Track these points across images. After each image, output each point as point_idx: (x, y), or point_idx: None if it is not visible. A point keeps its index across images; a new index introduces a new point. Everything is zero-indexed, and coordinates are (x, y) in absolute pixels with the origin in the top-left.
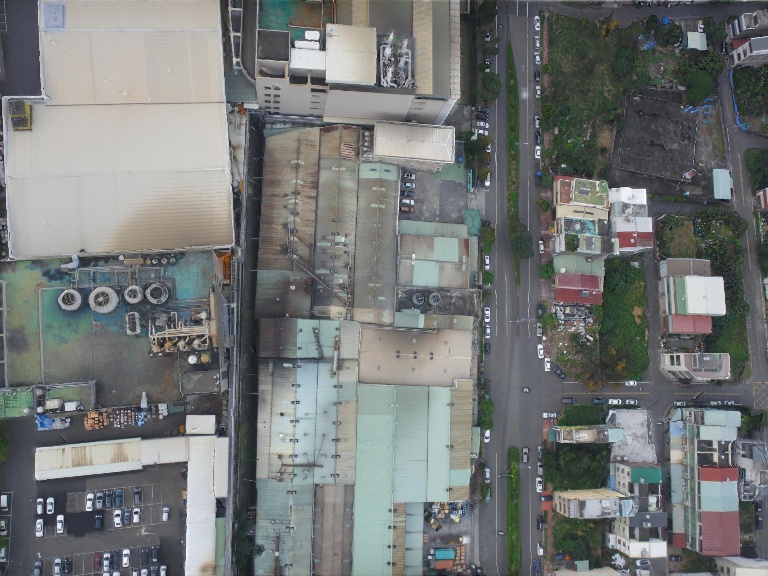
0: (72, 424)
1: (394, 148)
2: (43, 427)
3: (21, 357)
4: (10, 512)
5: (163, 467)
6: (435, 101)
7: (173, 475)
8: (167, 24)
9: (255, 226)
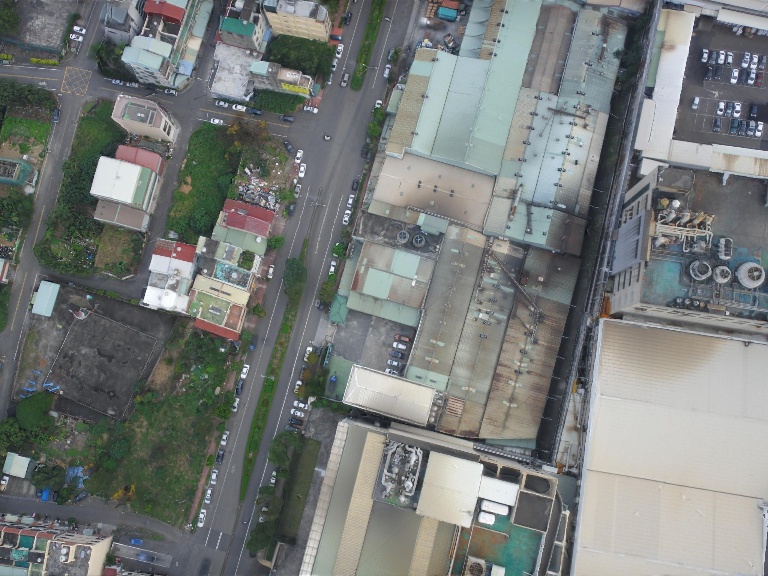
0: None
1: (413, 393)
2: None
3: None
4: None
5: None
6: None
7: (683, 135)
8: (632, 564)
9: (563, 350)
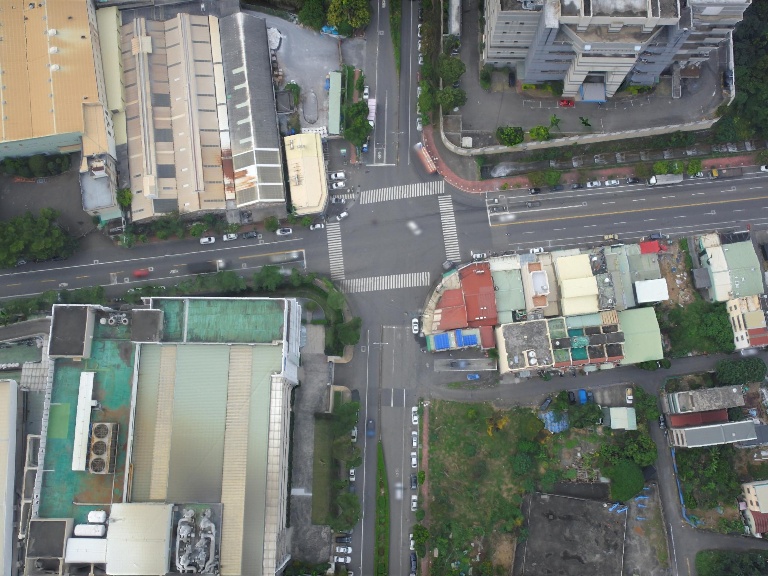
0: None
1: None
2: None
3: None
4: None
5: None
6: None
7: None
8: None
9: None
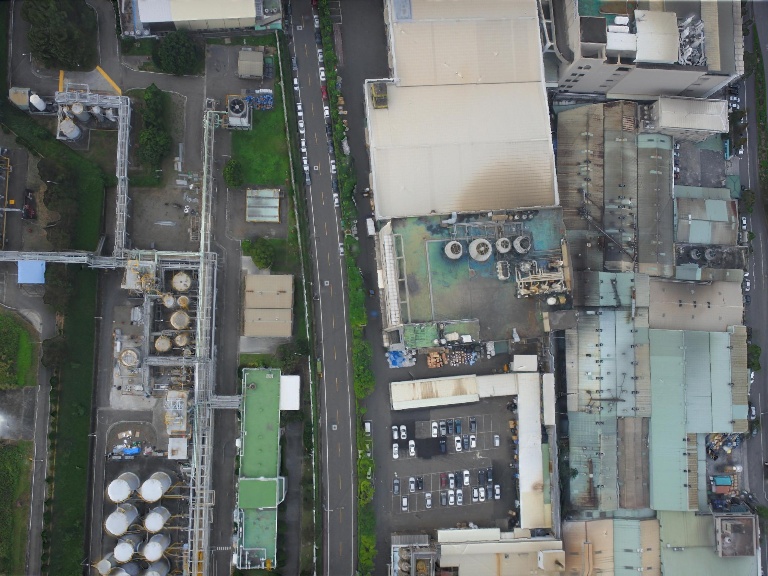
0: (418, 362)
1: (676, 120)
2: (394, 365)
3: (414, 299)
4: (371, 437)
5: (494, 400)
6: (719, 77)
7: (500, 407)
8: (494, 14)
9: None
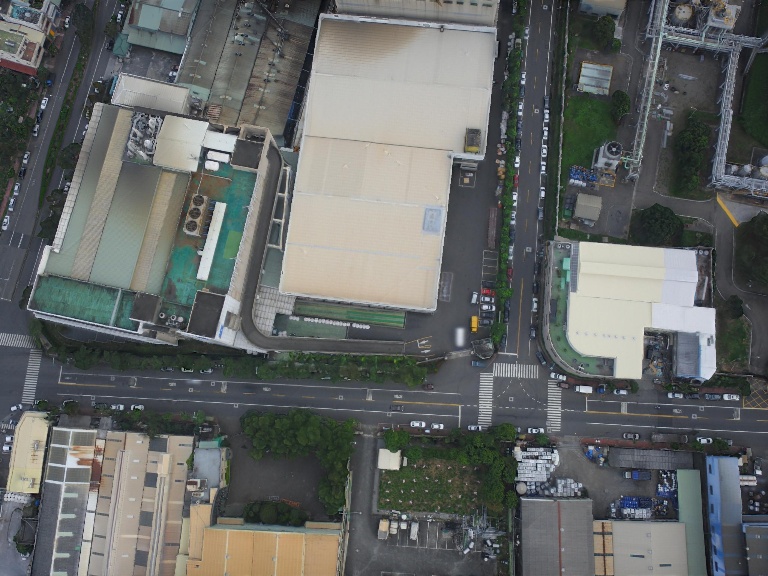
0: None
1: (170, 93)
2: None
3: None
4: None
5: None
6: None
7: None
8: (339, 203)
9: (308, 64)
